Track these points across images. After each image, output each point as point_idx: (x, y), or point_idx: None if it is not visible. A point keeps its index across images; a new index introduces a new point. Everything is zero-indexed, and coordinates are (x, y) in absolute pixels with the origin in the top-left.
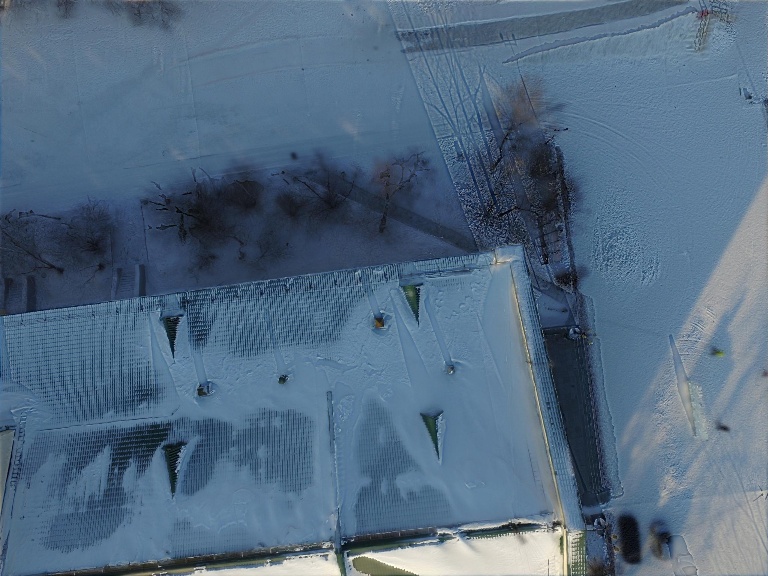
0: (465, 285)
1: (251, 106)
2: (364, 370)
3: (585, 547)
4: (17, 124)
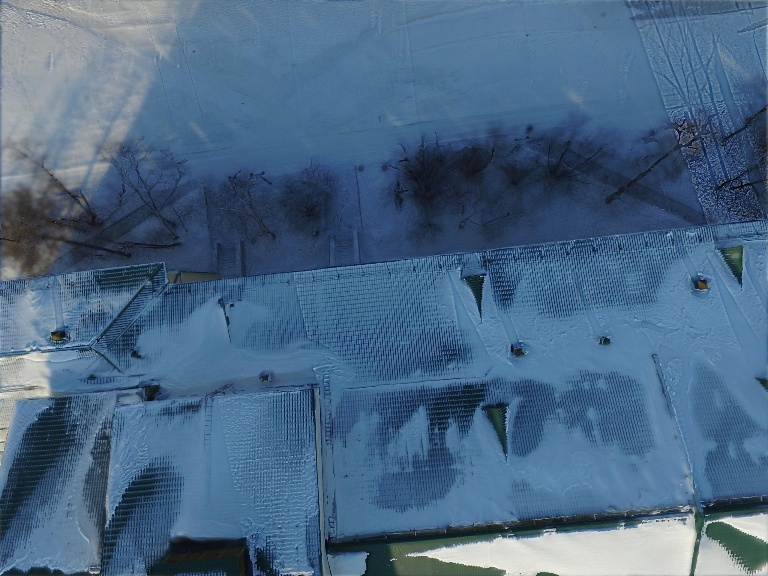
0: None
1: (472, 72)
2: (687, 333)
3: None
4: (227, 86)
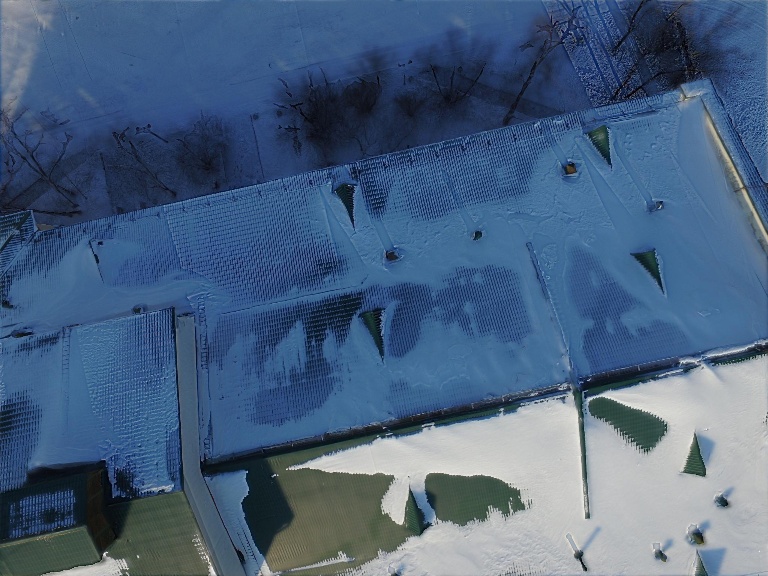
0: (653, 126)
1: (357, 9)
2: (561, 219)
3: None
4: (114, 49)
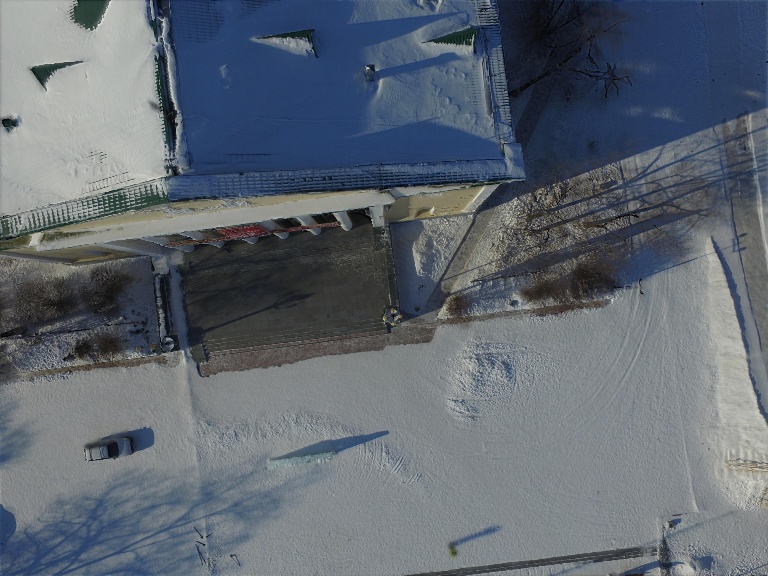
0: (474, 107)
1: None
2: None
3: (146, 205)
4: None
